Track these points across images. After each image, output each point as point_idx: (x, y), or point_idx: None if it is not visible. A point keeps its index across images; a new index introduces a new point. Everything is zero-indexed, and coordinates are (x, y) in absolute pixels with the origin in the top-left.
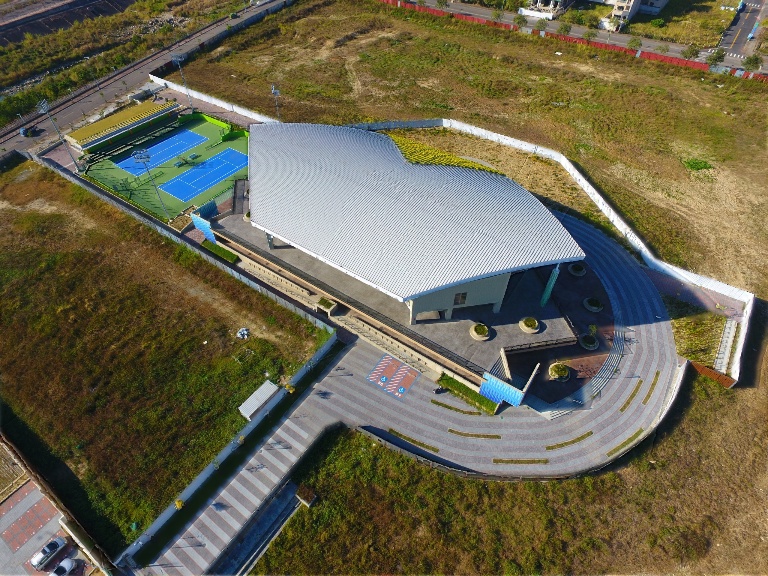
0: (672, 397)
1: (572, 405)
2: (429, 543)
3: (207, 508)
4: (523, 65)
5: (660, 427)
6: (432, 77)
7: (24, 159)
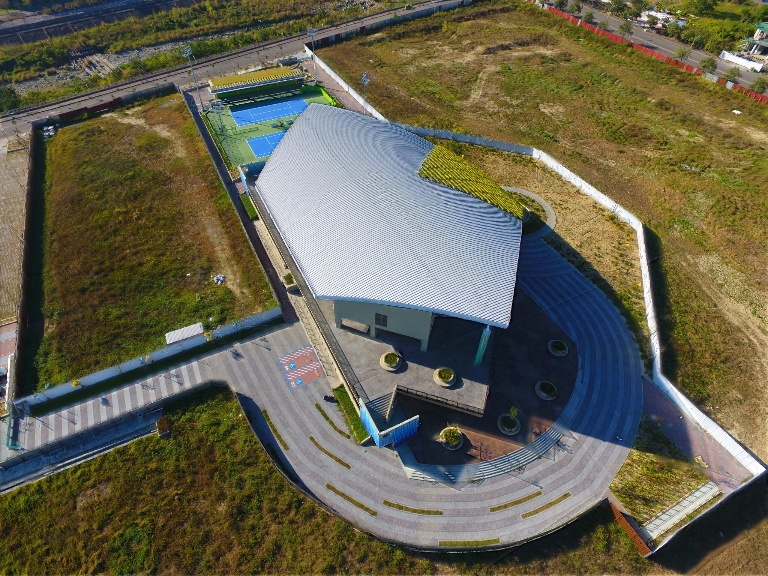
0: (562, 528)
1: (442, 476)
2: (220, 520)
3: (97, 398)
4: (678, 115)
5: (521, 549)
6: (560, 104)
7: (176, 91)
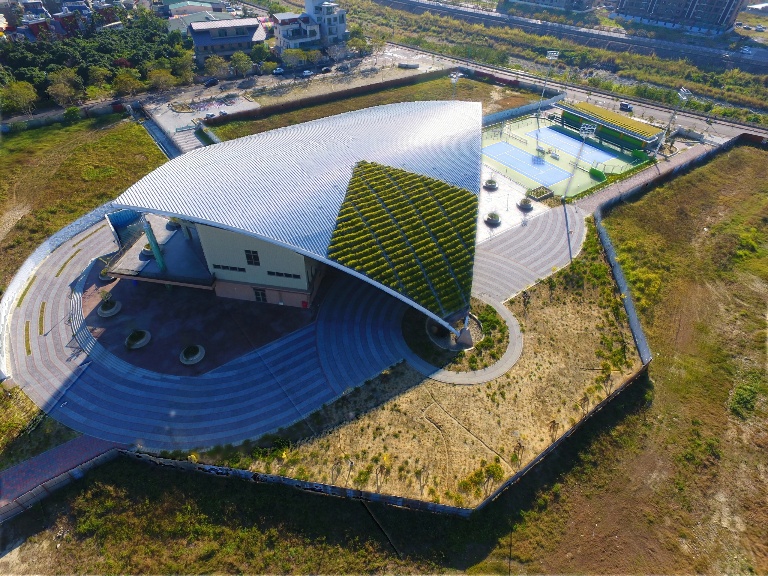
0: (3, 345)
1: None
2: None
3: (202, 143)
4: None
5: None
6: None
7: None
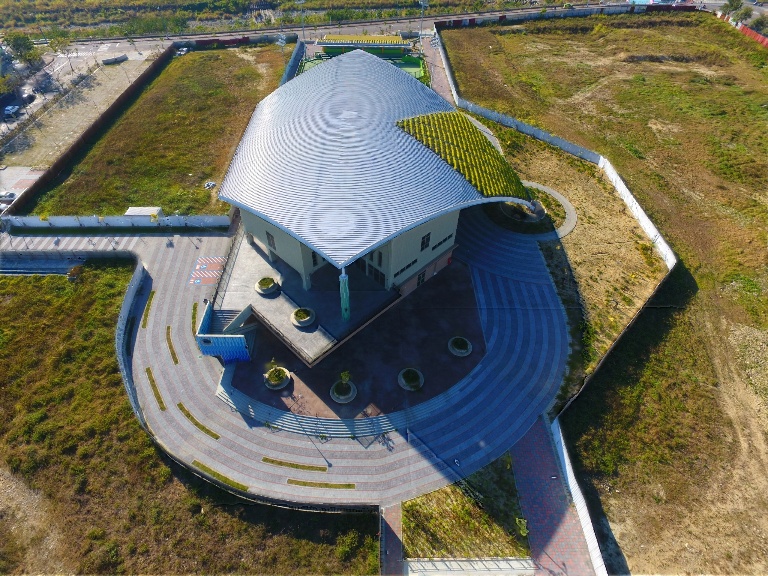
0: (317, 512)
1: (244, 407)
2: None
3: (55, 237)
4: None
5: (260, 508)
6: (679, 124)
7: None
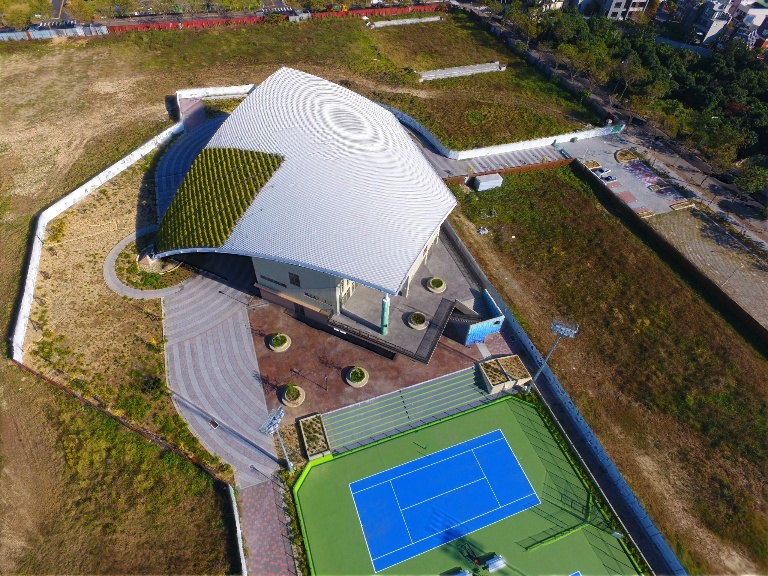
0: None
1: None
2: None
3: None
4: None
5: None
6: None
7: None
